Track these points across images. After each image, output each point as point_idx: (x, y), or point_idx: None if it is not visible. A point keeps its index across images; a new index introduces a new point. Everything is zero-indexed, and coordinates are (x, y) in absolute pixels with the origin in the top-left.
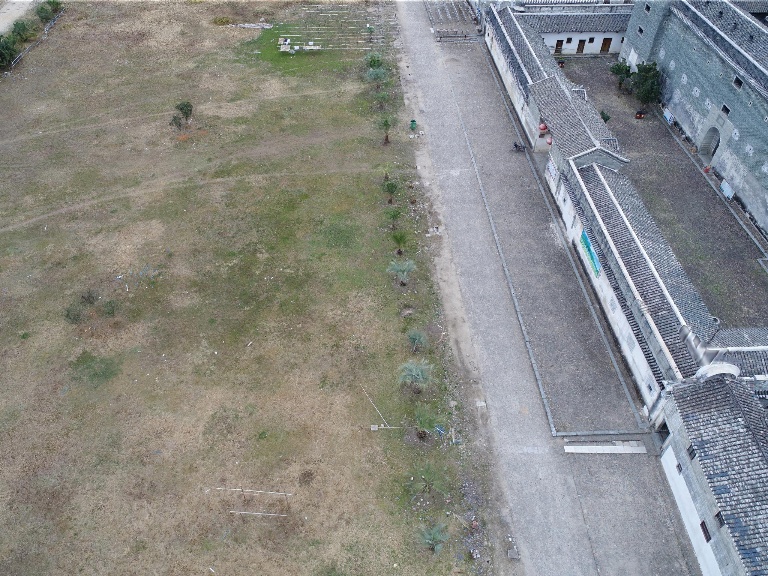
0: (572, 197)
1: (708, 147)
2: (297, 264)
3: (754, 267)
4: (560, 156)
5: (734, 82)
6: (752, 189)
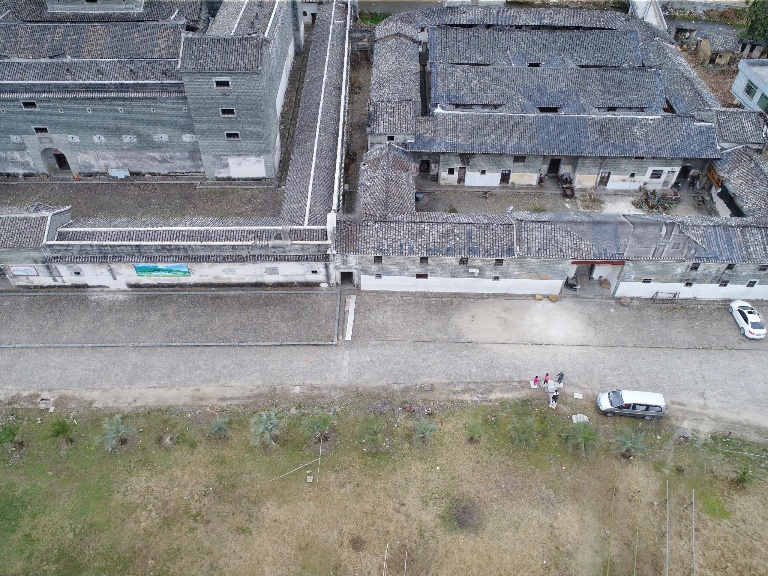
0: (91, 260)
1: (51, 167)
2: (31, 573)
3: (204, 192)
4: (25, 252)
5: (24, 107)
6: (132, 159)
